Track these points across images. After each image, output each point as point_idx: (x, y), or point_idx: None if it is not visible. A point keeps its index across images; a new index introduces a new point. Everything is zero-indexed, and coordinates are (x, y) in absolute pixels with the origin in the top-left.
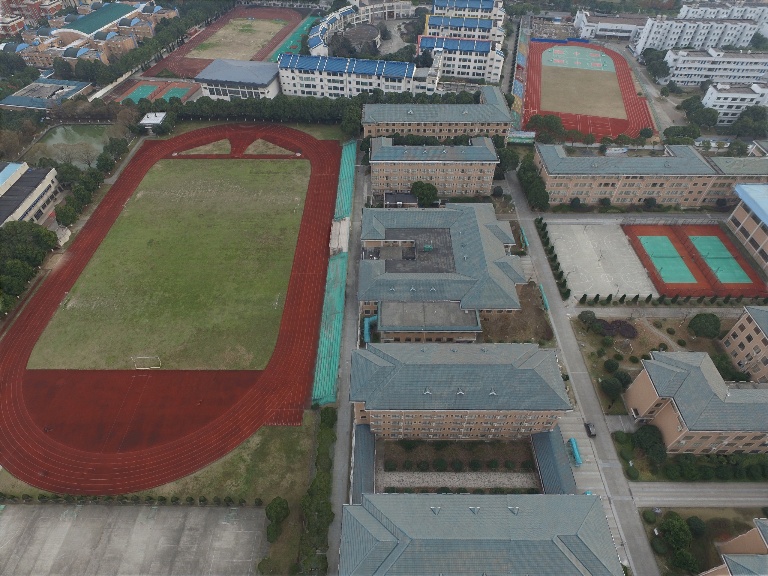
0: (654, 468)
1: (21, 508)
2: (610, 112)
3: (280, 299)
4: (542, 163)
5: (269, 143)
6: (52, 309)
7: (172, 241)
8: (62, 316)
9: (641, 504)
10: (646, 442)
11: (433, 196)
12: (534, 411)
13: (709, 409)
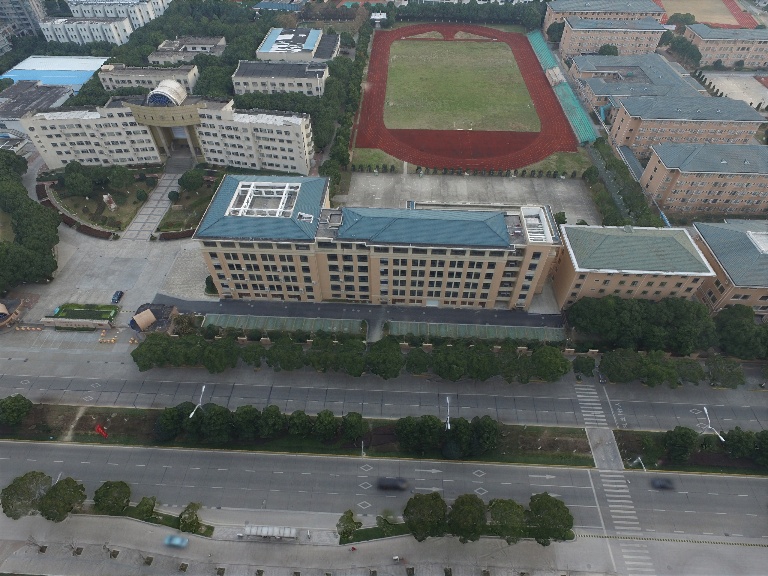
0: None
1: (432, 176)
2: (725, 21)
3: (530, 104)
4: (695, 34)
5: (469, 33)
6: (381, 106)
7: (436, 78)
8: (390, 108)
9: None
10: None
11: (616, 55)
12: (742, 125)
13: None
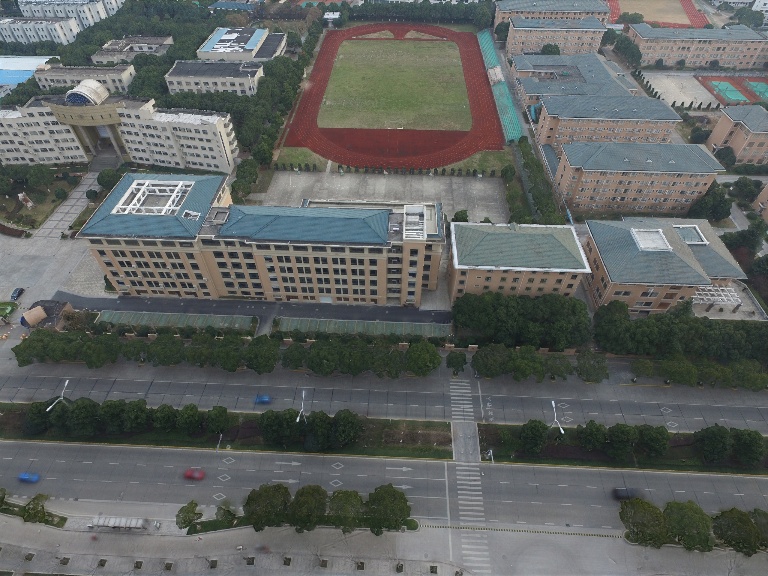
0: (728, 169)
1: (353, 174)
2: (677, 20)
3: None
4: (636, 34)
5: (421, 33)
6: (317, 105)
7: (378, 78)
8: (326, 108)
9: (721, 182)
10: (723, 154)
11: (558, 54)
12: (658, 124)
13: (765, 121)
